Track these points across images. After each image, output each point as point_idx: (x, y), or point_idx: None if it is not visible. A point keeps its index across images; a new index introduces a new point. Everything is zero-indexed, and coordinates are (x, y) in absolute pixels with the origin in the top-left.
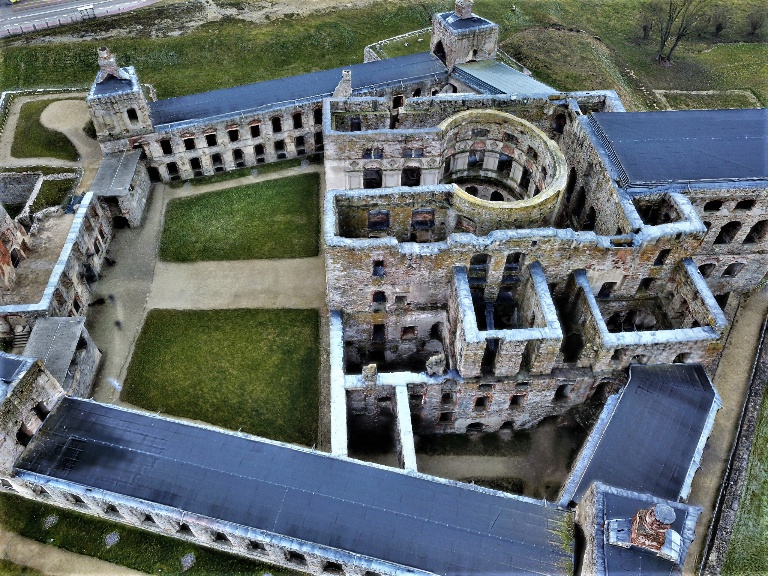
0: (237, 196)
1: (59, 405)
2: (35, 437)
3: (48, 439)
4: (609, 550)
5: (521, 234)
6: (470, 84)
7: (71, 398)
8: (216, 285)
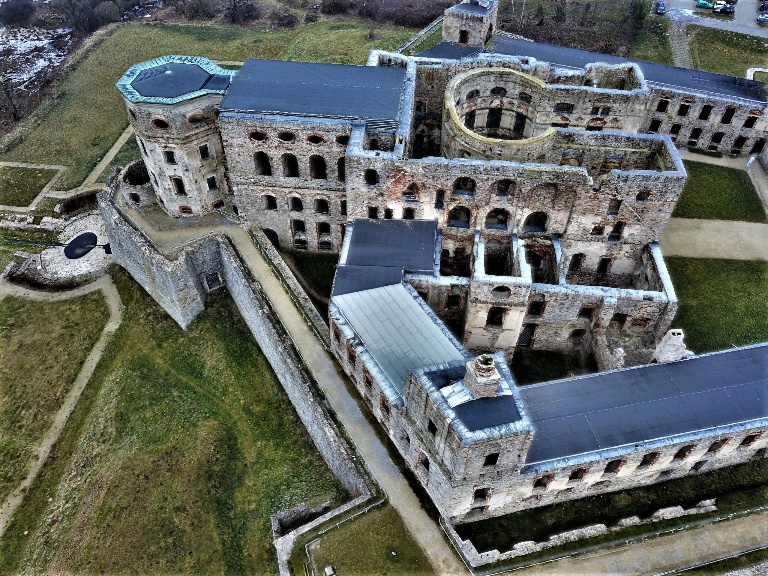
0: (759, 337)
1: (767, 99)
2: (767, 89)
3: (759, 88)
4: (490, 4)
5: (500, 58)
6: (464, 350)
7: (763, 102)
8: (722, 238)
